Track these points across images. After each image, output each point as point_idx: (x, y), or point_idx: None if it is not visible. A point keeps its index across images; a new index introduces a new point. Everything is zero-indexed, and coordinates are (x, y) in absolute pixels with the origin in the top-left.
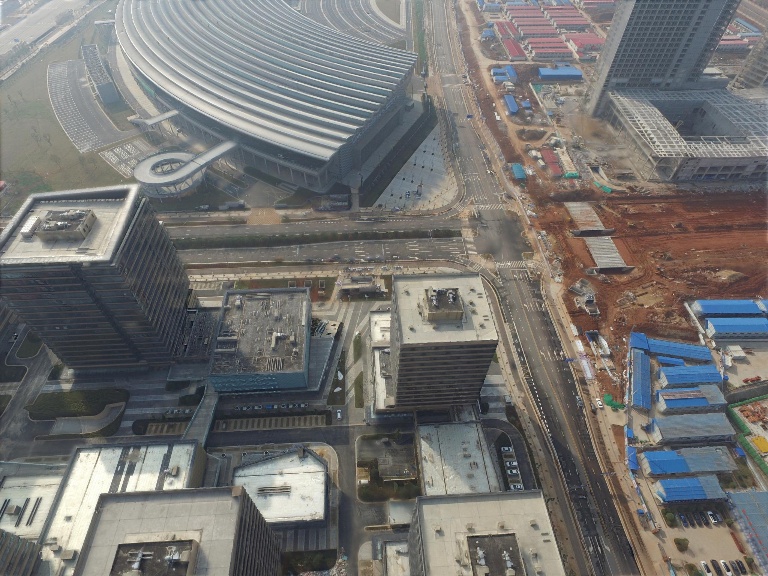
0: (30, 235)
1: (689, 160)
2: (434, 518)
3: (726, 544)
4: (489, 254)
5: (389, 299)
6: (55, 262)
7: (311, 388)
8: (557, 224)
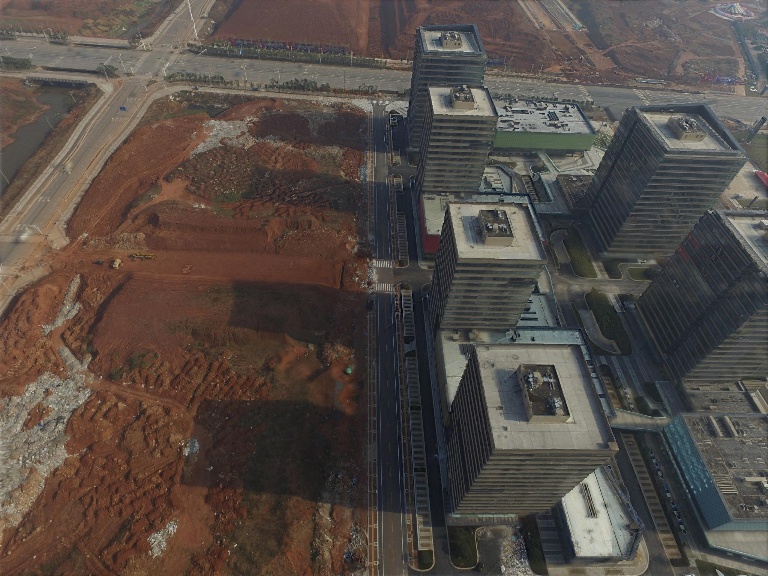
0: (763, 228)
1: None
2: None
3: None
4: None
5: None
6: (749, 253)
7: (710, 536)
8: None
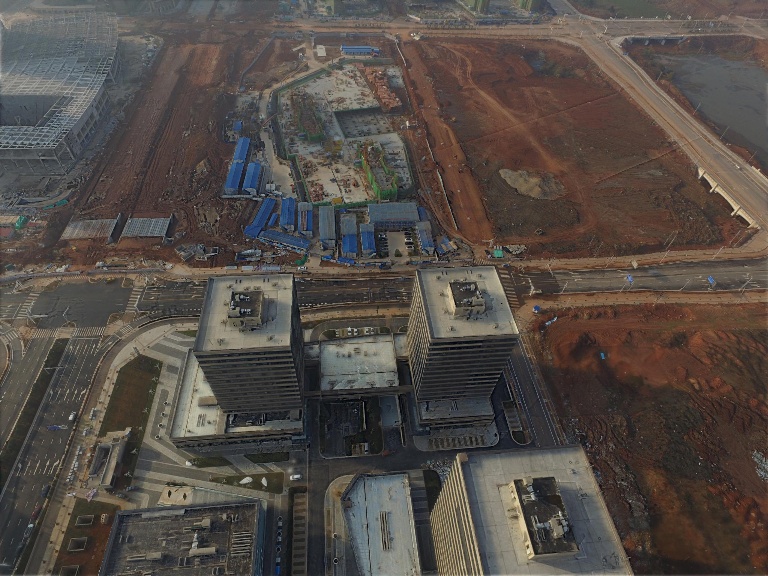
0: None
1: (67, 136)
2: (443, 331)
3: (396, 236)
4: (111, 316)
5: (144, 426)
6: None
7: None
8: (91, 251)
